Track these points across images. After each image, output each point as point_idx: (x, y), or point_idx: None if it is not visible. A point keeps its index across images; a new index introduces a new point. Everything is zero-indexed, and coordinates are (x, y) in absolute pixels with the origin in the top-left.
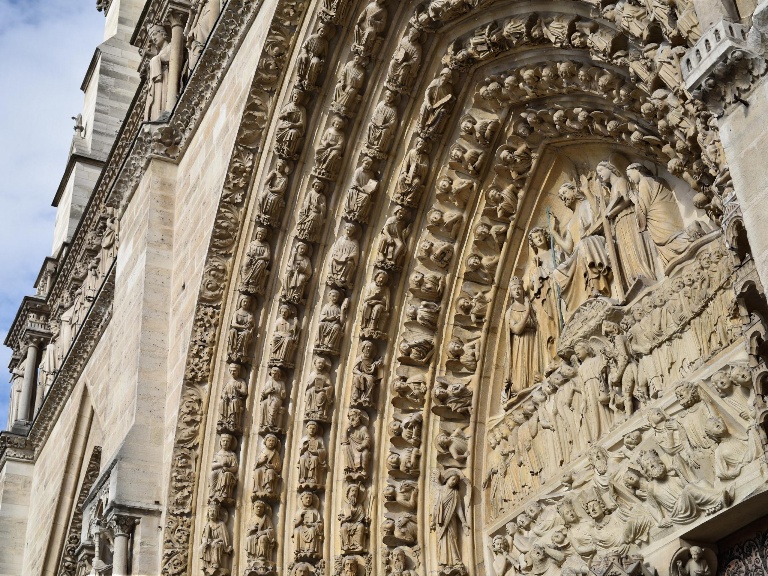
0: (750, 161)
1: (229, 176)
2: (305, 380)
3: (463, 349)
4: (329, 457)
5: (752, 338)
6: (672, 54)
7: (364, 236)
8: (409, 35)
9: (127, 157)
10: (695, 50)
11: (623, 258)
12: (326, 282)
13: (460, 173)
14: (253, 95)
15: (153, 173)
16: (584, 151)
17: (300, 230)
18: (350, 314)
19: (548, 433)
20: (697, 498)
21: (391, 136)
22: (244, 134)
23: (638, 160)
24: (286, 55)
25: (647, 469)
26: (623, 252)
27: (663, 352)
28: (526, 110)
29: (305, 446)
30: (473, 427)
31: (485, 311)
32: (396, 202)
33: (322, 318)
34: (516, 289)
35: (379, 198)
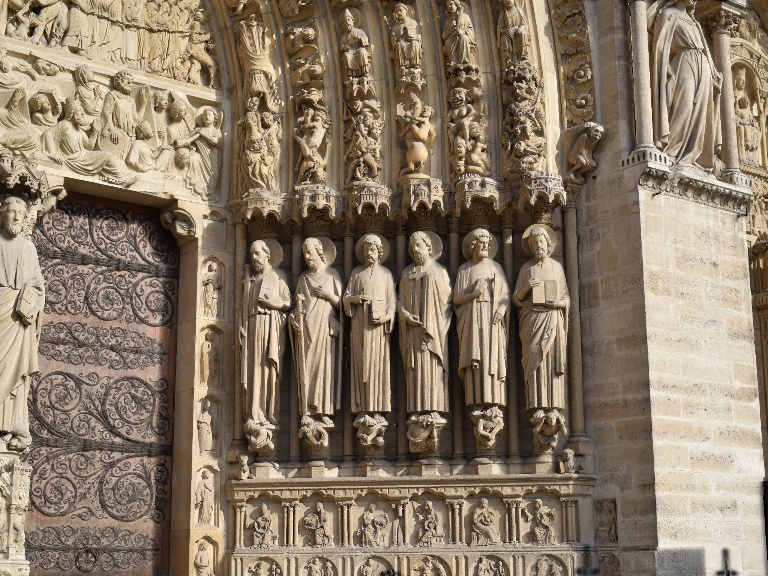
0: None
1: None
2: None
3: None
4: None
5: None
6: None
7: None
8: None
9: None
10: None
11: None
12: None
13: None
14: None
15: None
16: None
17: None
18: None
19: None
20: (111, 166)
21: None
22: None
23: None
24: None
25: (76, 112)
26: None
27: (103, 25)
28: None
29: None
30: None
31: None
32: None
33: None
34: None
35: None
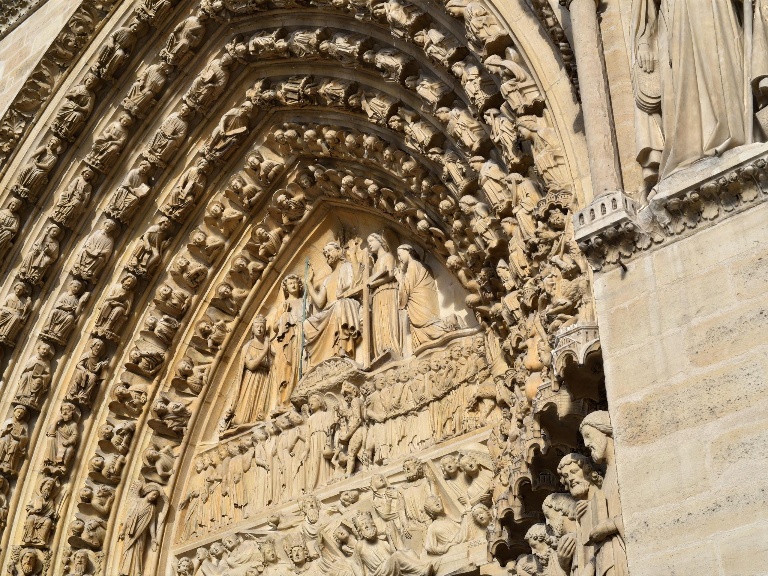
0: (620, 318)
1: None
2: (23, 362)
3: (193, 370)
4: (30, 445)
5: (531, 448)
6: (511, 178)
7: (121, 236)
8: (222, 59)
9: None
10: (590, 208)
11: (376, 328)
12: (71, 271)
13: (233, 203)
14: (43, 65)
15: None
16: (357, 217)
17: (58, 212)
18: (87, 308)
19: (261, 471)
20: (403, 565)
21: (175, 148)
22: (22, 100)
23: (408, 241)
24: (89, 37)
25: (361, 529)
26: (377, 322)
27: (397, 424)
28: (316, 164)
29: (8, 429)
30: (184, 447)
31: (223, 339)
32: (164, 213)
33: (58, 305)
34: (259, 327)
35: (146, 203)
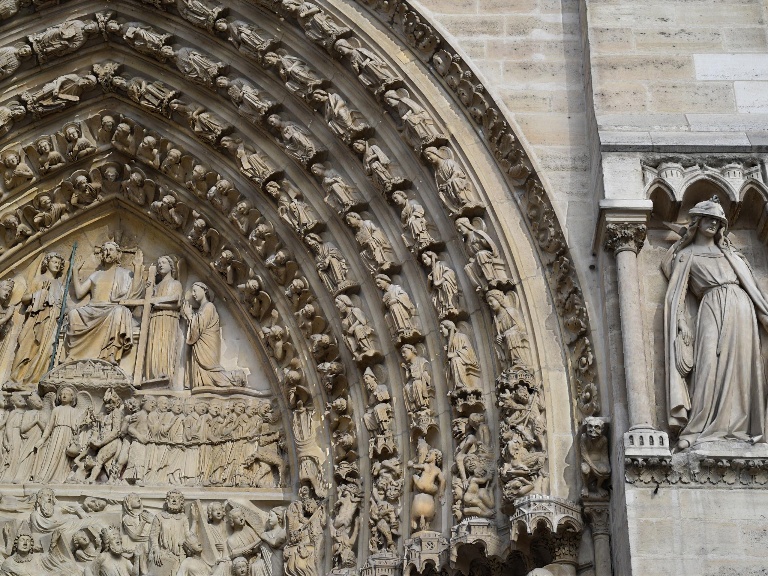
0: (648, 529)
1: None
2: None
3: None
4: None
5: (425, 561)
6: (449, 325)
7: None
8: (89, 25)
9: None
10: (640, 435)
11: (155, 350)
12: None
13: (28, 159)
14: None
15: None
16: (146, 229)
17: None
18: None
19: None
20: None
21: None
22: None
23: (198, 278)
24: None
25: (110, 541)
26: (157, 345)
27: (160, 451)
28: (136, 167)
29: None
30: None
31: None
32: None
33: None
34: (8, 290)
35: None
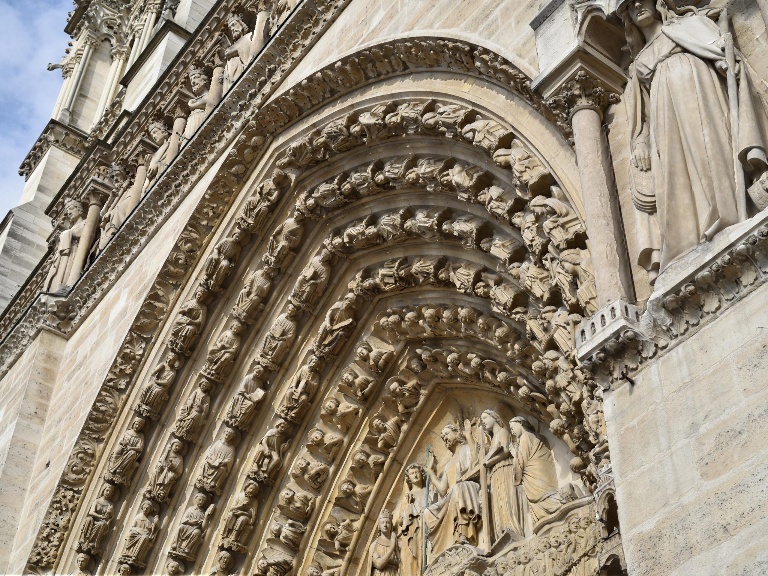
0: (629, 438)
1: (117, 361)
2: None
3: (322, 575)
4: None
5: None
6: (568, 320)
7: (242, 444)
8: (321, 255)
9: (17, 323)
10: (591, 323)
11: (495, 509)
12: (195, 484)
13: (348, 397)
14: (157, 285)
15: (40, 344)
16: (472, 396)
17: (178, 427)
18: (213, 521)
19: None
20: None
21: (286, 349)
22: (141, 322)
23: (523, 414)
24: (197, 253)
25: None
26: (495, 503)
27: None
28: (422, 347)
29: None
30: None
31: (350, 540)
32: (280, 415)
33: (184, 520)
34: (385, 522)
35: (264, 408)
